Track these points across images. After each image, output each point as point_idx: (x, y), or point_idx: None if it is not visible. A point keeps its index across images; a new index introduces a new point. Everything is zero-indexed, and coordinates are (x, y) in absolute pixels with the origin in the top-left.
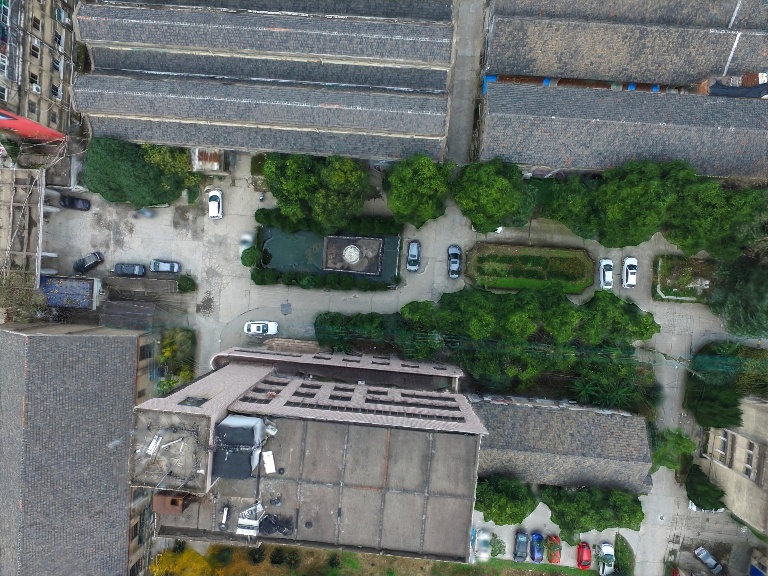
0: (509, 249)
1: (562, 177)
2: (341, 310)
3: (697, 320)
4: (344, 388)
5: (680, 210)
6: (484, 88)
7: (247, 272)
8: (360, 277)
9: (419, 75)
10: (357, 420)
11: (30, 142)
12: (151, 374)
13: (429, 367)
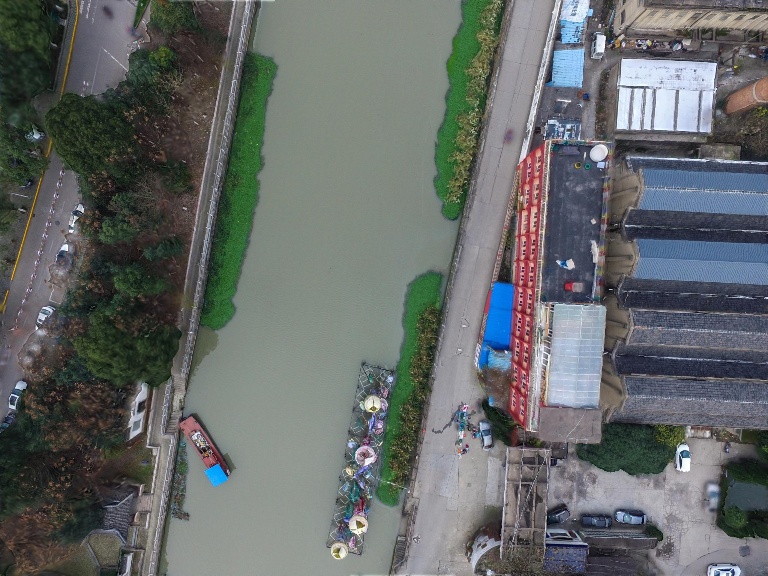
0: None
1: None
2: None
3: None
4: None
5: None
6: None
7: (707, 517)
8: None
9: None
10: None
11: None
12: None
13: None
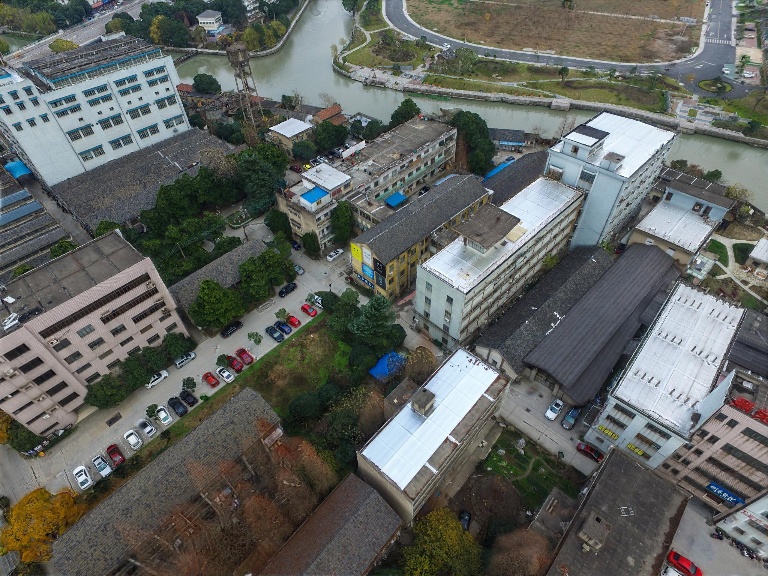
0: None
1: None
2: None
3: (260, 222)
4: None
5: (187, 189)
6: None
7: None
8: None
9: None
10: None
11: None
12: None
13: None
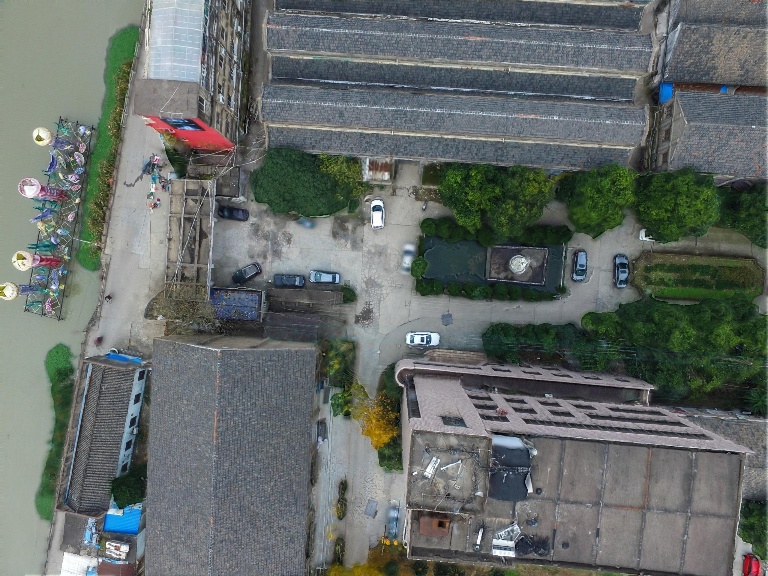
0: (677, 258)
1: (747, 186)
2: (503, 320)
3: None
4: (546, 402)
5: None
6: (660, 96)
7: (407, 282)
8: (526, 287)
9: (606, 84)
10: (618, 439)
11: (199, 152)
12: (317, 386)
13: (611, 379)
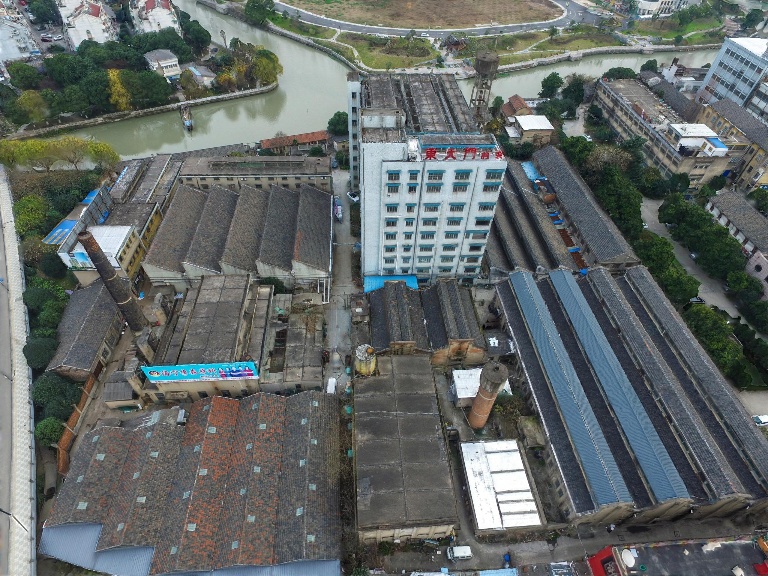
0: None
1: None
2: (757, 336)
3: None
4: None
5: None
6: None
7: None
8: (731, 325)
9: None
10: None
11: None
12: None
13: (762, 273)
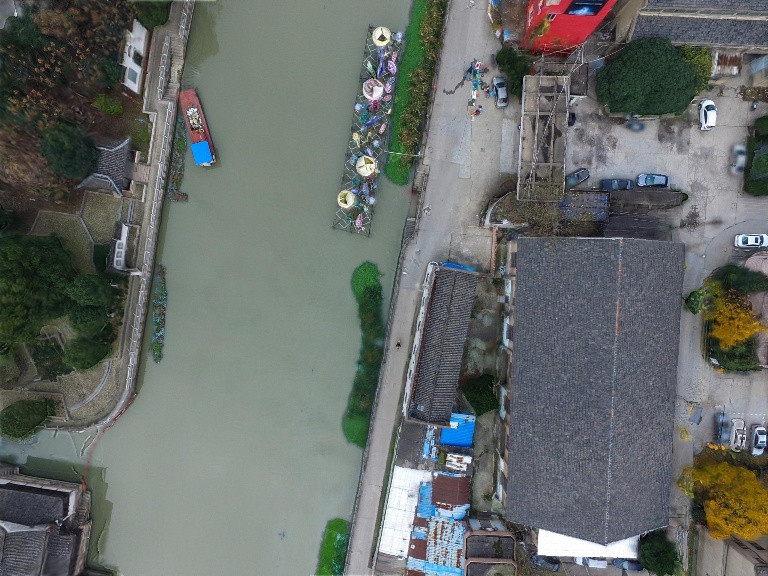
0: None
1: None
2: None
3: None
4: None
5: None
6: None
7: (734, 185)
8: None
9: None
10: None
11: (550, 49)
12: None
13: None
